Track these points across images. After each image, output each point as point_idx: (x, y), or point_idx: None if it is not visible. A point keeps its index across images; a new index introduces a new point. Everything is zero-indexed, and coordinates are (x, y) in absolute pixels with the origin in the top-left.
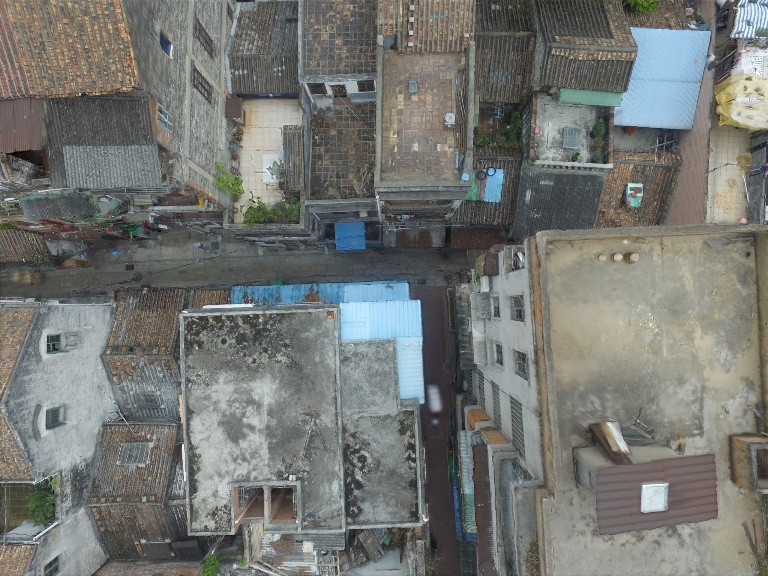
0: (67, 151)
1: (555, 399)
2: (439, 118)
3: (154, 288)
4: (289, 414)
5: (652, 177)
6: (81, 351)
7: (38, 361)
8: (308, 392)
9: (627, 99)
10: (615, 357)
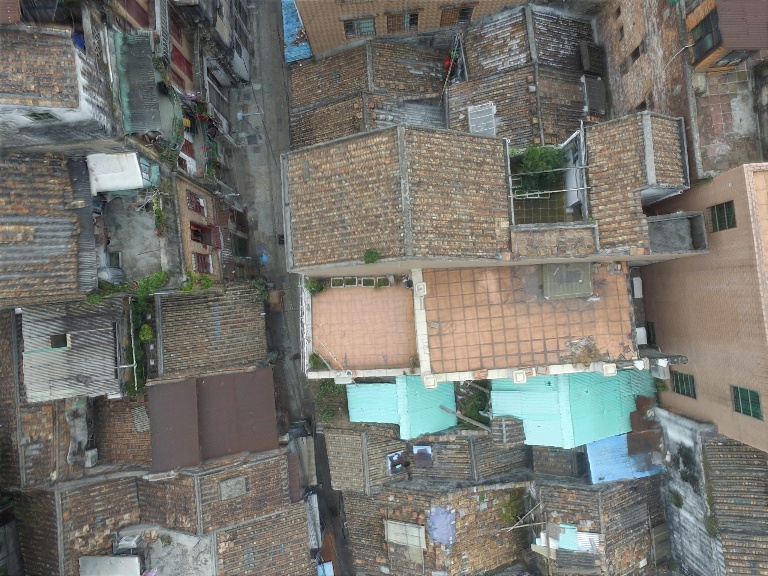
0: None
1: None
2: None
3: None
4: None
5: None
6: None
7: None
8: None
9: None
10: None
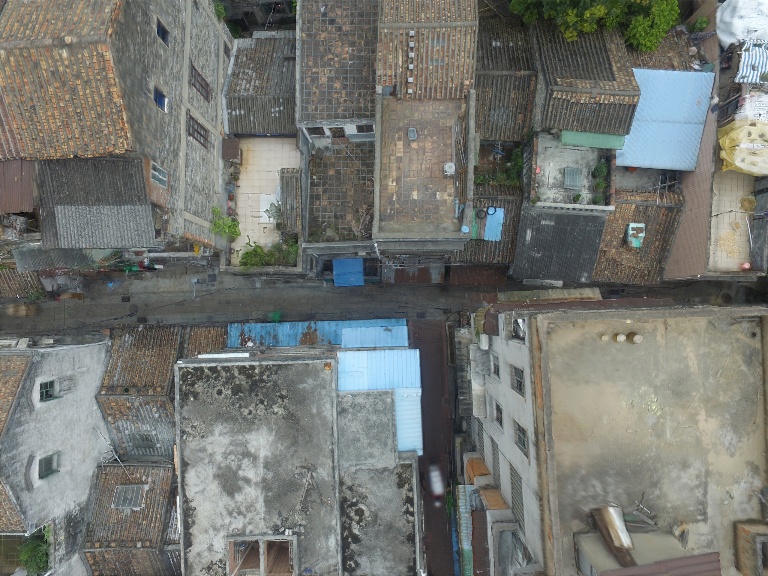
0: (59, 211)
1: (556, 489)
2: (439, 166)
3: (150, 325)
4: (285, 467)
5: (654, 217)
6: (75, 394)
7: (31, 411)
8: (305, 444)
9: (629, 140)
10: (617, 440)
